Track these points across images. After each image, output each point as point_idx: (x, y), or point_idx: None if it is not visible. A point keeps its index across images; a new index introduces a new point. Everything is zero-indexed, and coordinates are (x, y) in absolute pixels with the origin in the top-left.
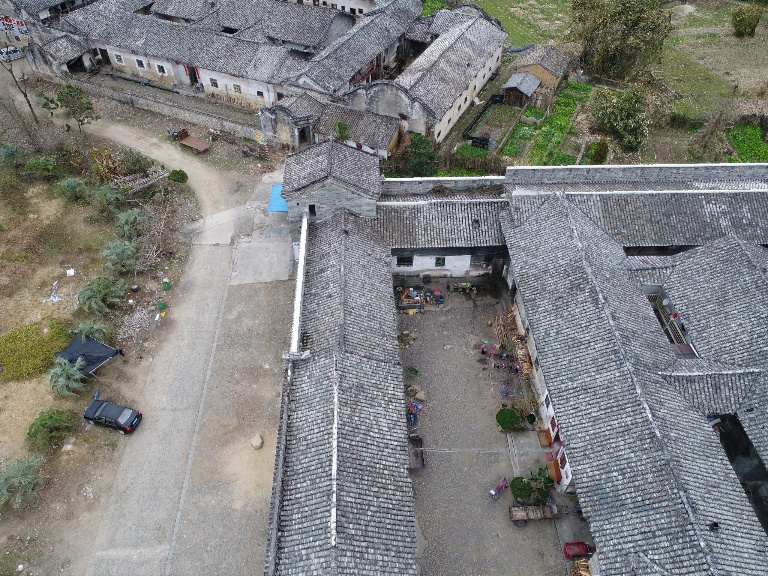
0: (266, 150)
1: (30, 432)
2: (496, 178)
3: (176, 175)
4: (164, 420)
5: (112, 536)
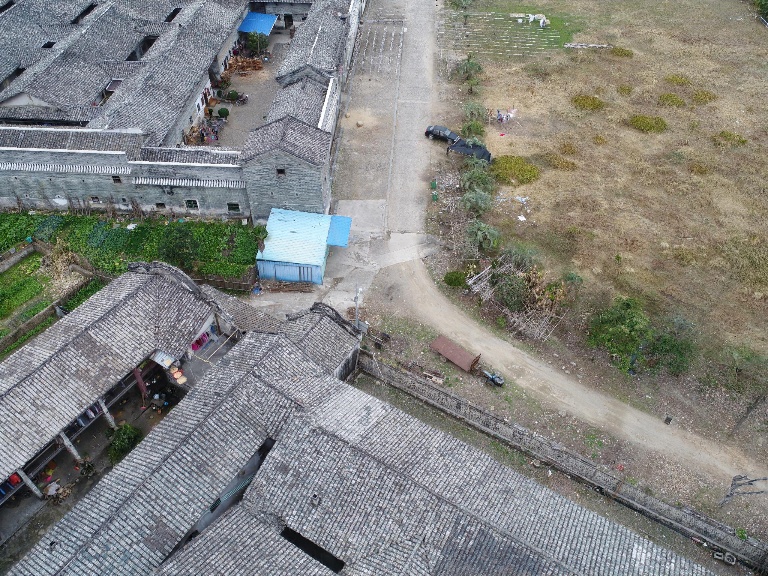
0: None
1: None
2: (137, 161)
3: None
4: (413, 137)
5: (425, 106)
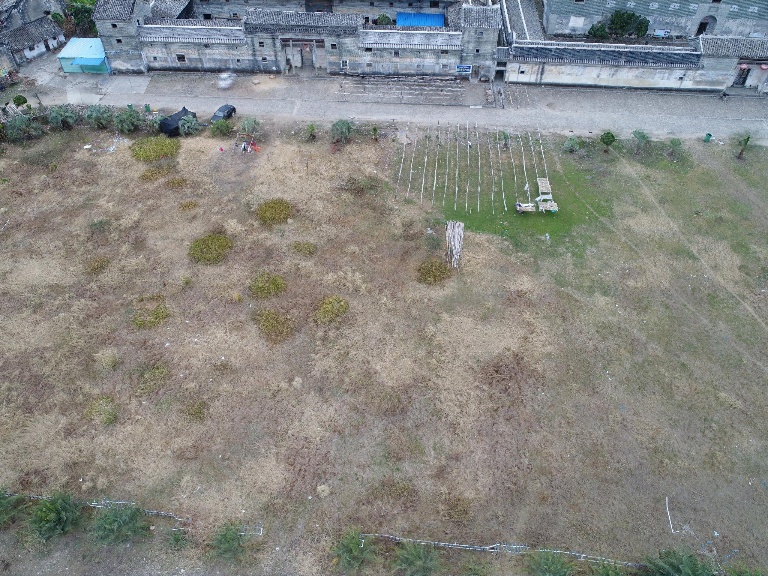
0: (9, 79)
1: (224, 129)
2: None
3: (20, 99)
4: None
5: (287, 113)
